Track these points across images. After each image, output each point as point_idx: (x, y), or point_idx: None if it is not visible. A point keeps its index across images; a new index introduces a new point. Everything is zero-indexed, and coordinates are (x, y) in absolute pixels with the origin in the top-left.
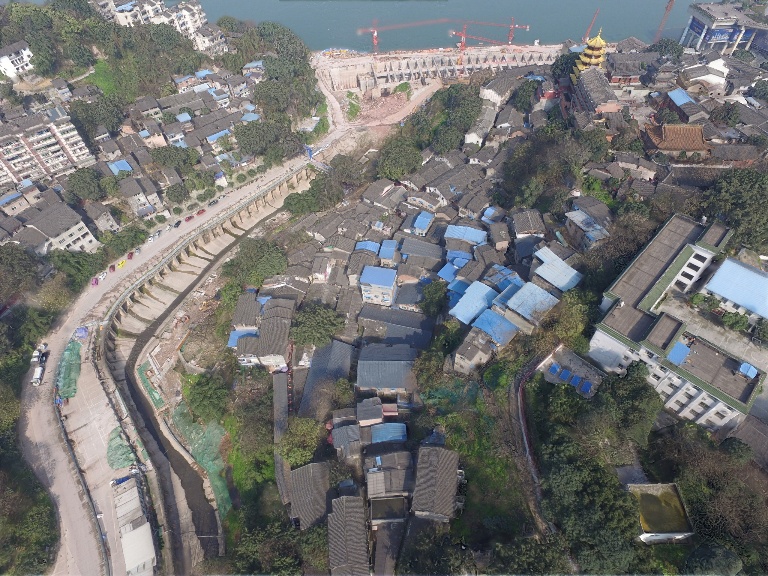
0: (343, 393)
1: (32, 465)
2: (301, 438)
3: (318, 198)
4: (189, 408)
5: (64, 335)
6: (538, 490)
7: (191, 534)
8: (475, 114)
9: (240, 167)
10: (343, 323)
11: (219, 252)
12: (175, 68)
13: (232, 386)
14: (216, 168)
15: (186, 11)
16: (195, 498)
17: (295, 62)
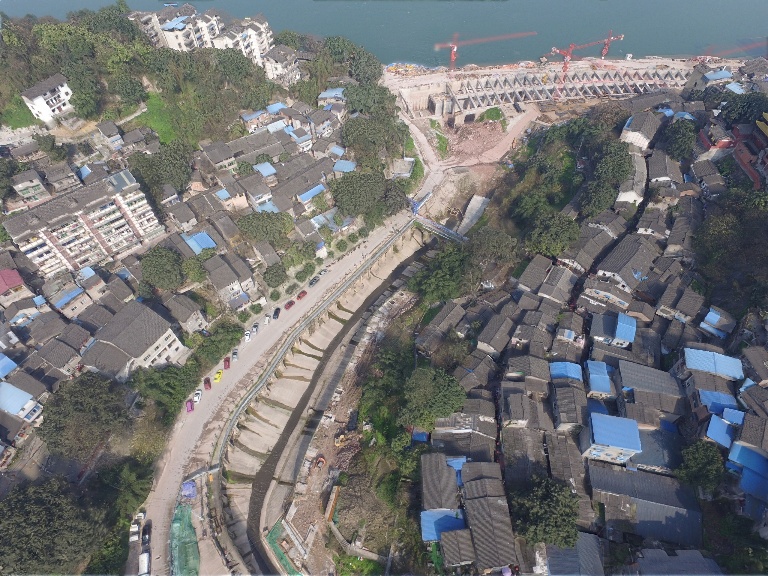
0: None
1: None
2: None
3: (460, 283)
4: None
5: (165, 494)
6: None
7: None
8: (630, 166)
9: (340, 232)
10: (577, 501)
11: (328, 345)
12: (245, 103)
13: None
14: (316, 237)
15: (253, 30)
16: None
17: None
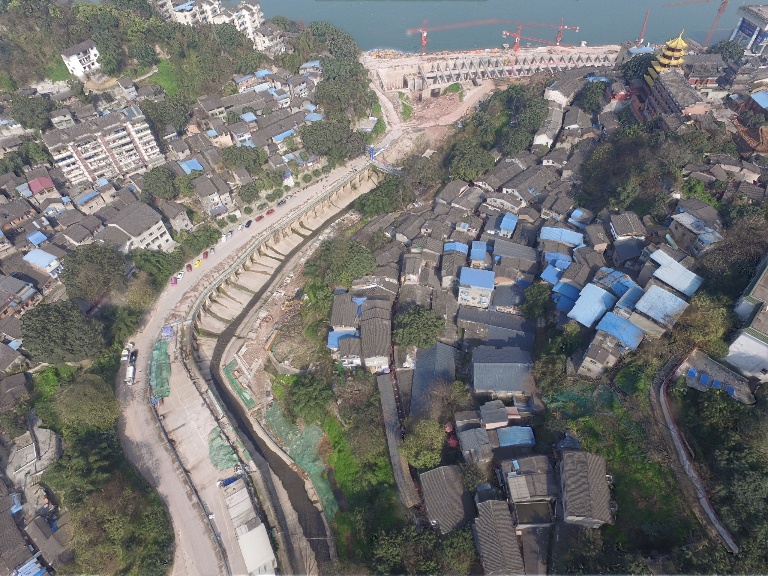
0: (461, 395)
1: (136, 465)
2: (429, 441)
3: (392, 199)
4: (284, 409)
5: (150, 334)
6: (717, 497)
7: (300, 536)
8: (544, 115)
9: (306, 167)
10: (443, 325)
11: (289, 252)
12: (237, 68)
13: (331, 387)
14: (284, 168)
15: (246, 11)
16: (299, 499)
17: (349, 62)
